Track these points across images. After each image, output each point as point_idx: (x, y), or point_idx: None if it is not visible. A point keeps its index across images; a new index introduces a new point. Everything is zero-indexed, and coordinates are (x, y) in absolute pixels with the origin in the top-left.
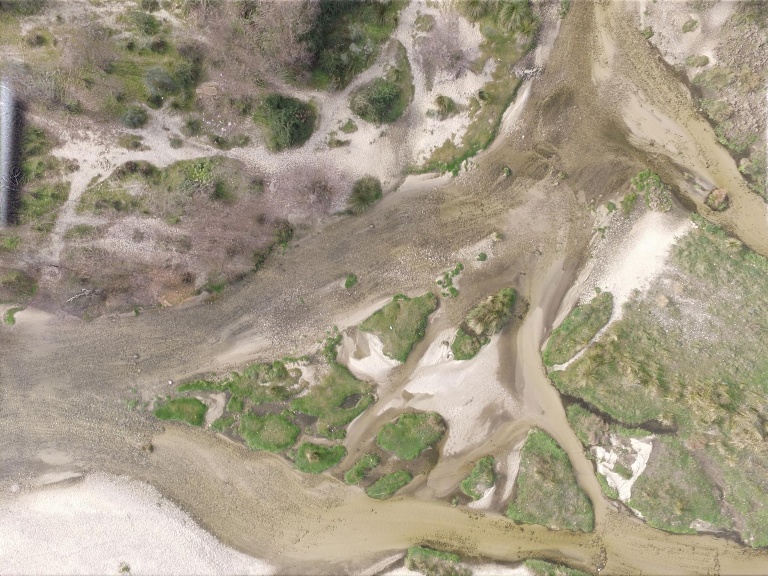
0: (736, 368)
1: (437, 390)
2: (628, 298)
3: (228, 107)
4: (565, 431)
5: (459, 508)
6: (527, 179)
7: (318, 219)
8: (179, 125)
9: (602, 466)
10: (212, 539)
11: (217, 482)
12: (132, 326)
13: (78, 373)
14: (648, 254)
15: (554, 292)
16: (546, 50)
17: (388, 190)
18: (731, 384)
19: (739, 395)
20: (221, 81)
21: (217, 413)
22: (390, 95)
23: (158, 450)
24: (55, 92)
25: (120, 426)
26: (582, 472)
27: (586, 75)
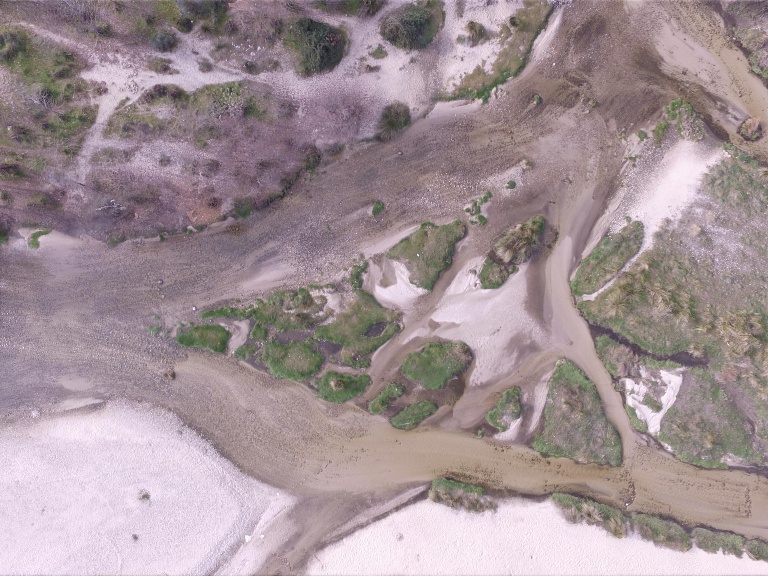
0: None
1: (464, 319)
2: (659, 227)
3: (258, 30)
4: (594, 362)
5: (485, 440)
6: (557, 107)
7: (346, 145)
8: (208, 49)
9: (631, 398)
10: (233, 468)
11: (239, 410)
12: (157, 251)
13: (101, 298)
14: (680, 183)
15: (584, 221)
16: None
17: (417, 117)
18: (764, 316)
19: None
20: (251, 5)
21: (241, 340)
22: (421, 19)
23: (180, 377)
24: (85, 14)
25: (142, 352)
26: (611, 404)
27: (618, 3)
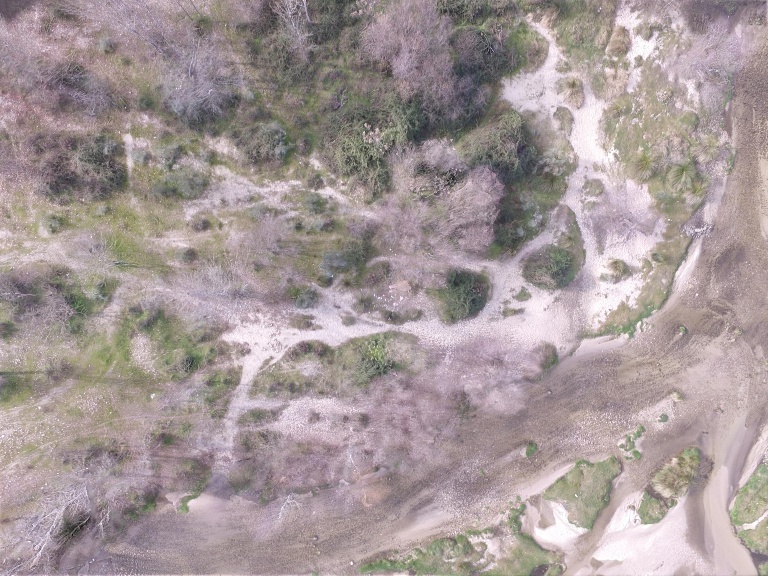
0: None
1: (626, 556)
2: None
3: None
4: None
5: None
6: (703, 337)
7: (494, 388)
8: (350, 302)
9: None
10: None
11: None
12: (309, 507)
13: (256, 559)
14: None
15: (738, 450)
16: (714, 207)
17: (564, 355)
18: None
19: None
20: (391, 256)
21: None
22: (567, 265)
23: None
24: (223, 276)
25: None
26: None
27: (755, 230)
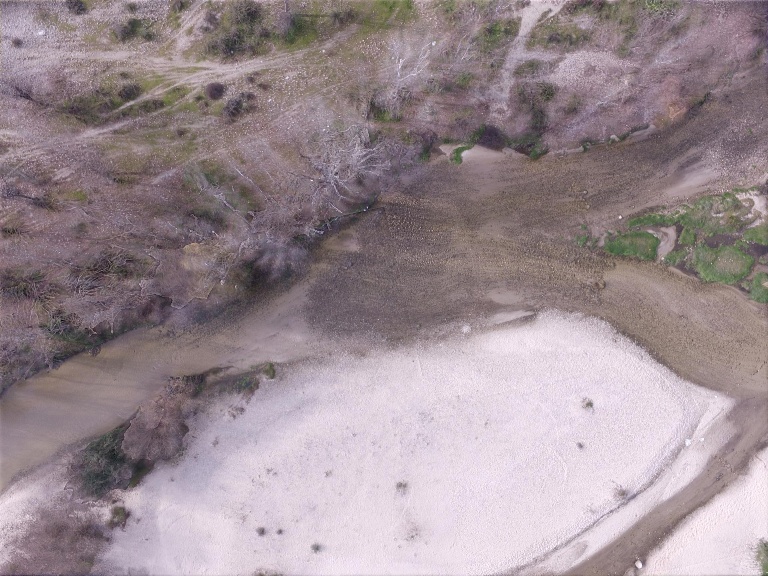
0: None
1: None
2: None
3: None
4: None
5: None
6: None
7: (764, 49)
8: None
9: None
10: (670, 373)
11: (671, 316)
12: (579, 162)
13: (526, 211)
14: None
15: None
16: None
17: None
18: None
19: None
20: None
21: (669, 246)
22: None
23: (610, 285)
24: None
25: (570, 263)
26: None
27: None
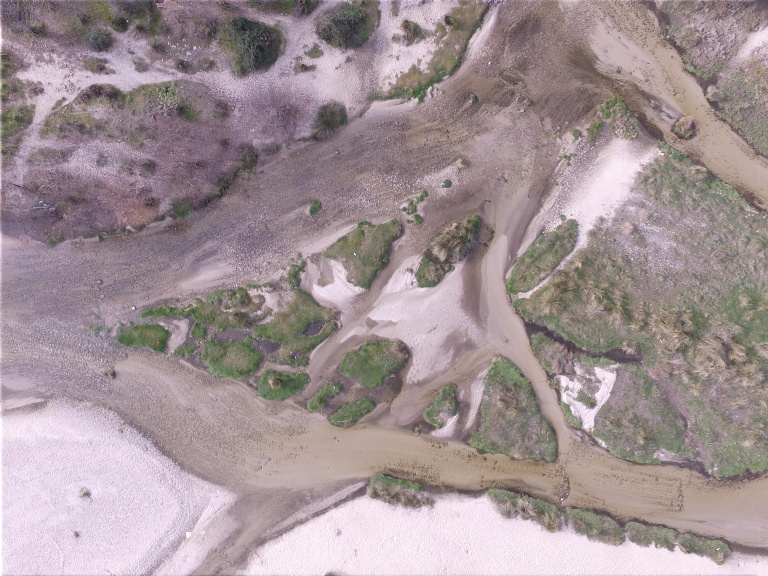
0: (701, 296)
1: (401, 317)
2: (593, 225)
3: (193, 30)
4: (529, 360)
5: (422, 437)
6: (493, 106)
7: (283, 145)
8: (144, 49)
9: (566, 395)
10: (174, 466)
11: (179, 409)
12: (96, 251)
13: (41, 298)
14: (614, 181)
15: (519, 220)
16: None
17: (353, 116)
18: (696, 313)
19: (704, 324)
20: (186, 4)
21: (180, 339)
22: (355, 18)
23: (121, 376)
24: (20, 14)
25: (83, 352)
26: (546, 401)
27: (553, 2)
